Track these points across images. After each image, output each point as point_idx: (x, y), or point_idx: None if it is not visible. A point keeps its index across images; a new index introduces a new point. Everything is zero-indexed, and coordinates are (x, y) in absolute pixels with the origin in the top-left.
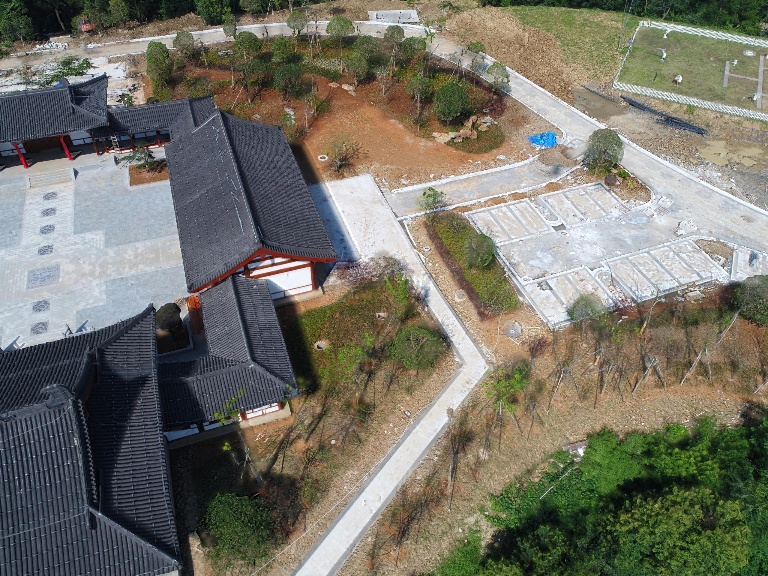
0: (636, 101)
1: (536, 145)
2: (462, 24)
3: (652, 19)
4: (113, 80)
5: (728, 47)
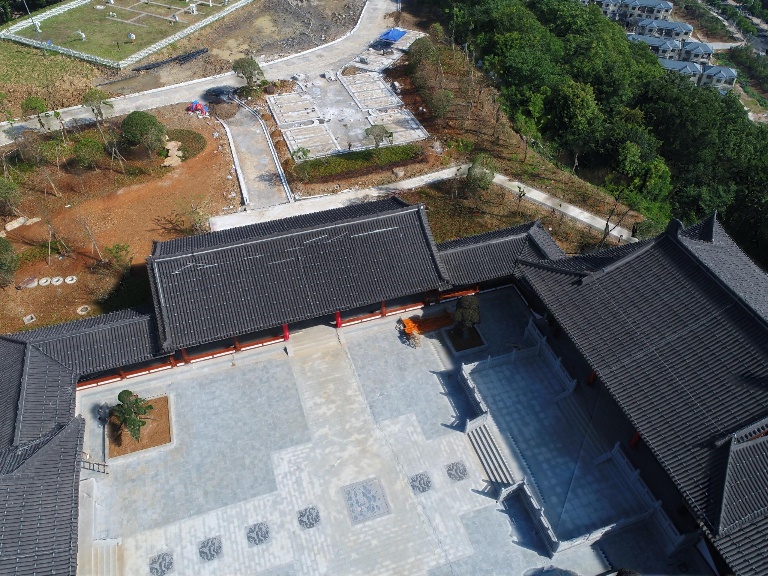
0: (144, 65)
1: (203, 116)
2: None
3: None
4: None
5: (82, 12)
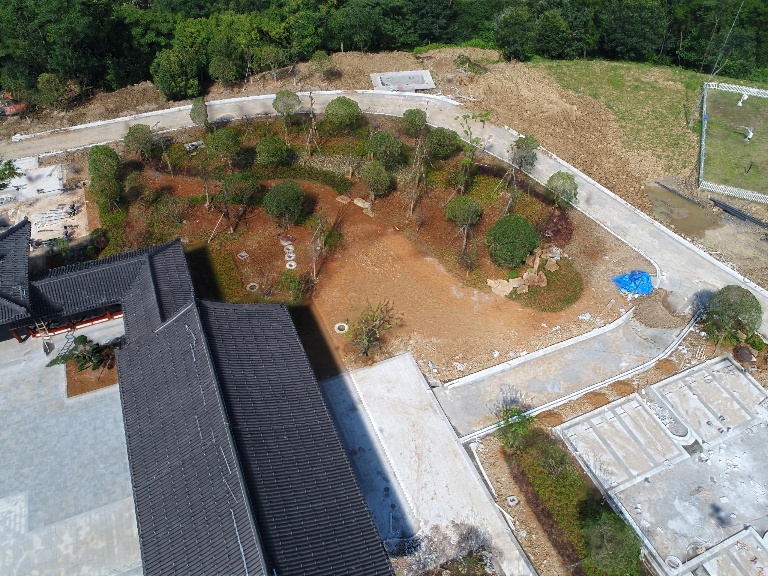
0: (731, 206)
1: (626, 292)
2: (490, 92)
3: (715, 76)
4: (45, 195)
5: None
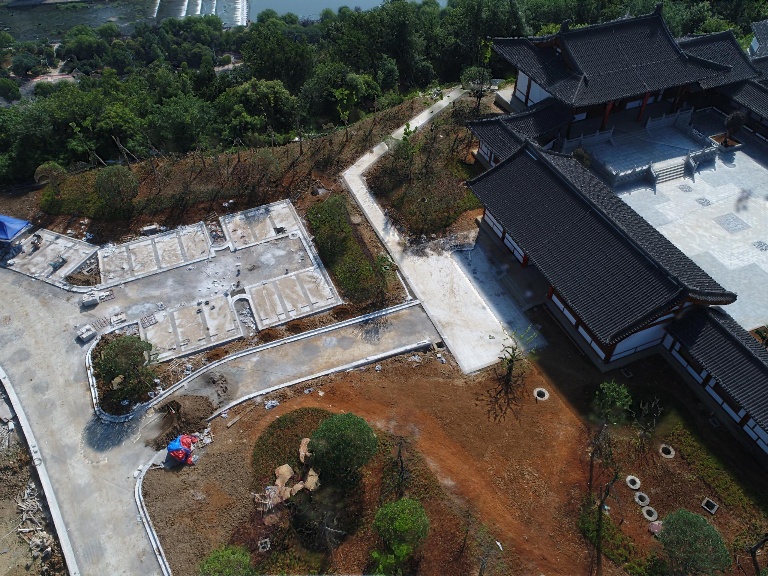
0: None
1: (206, 438)
2: None
3: None
4: None
5: None
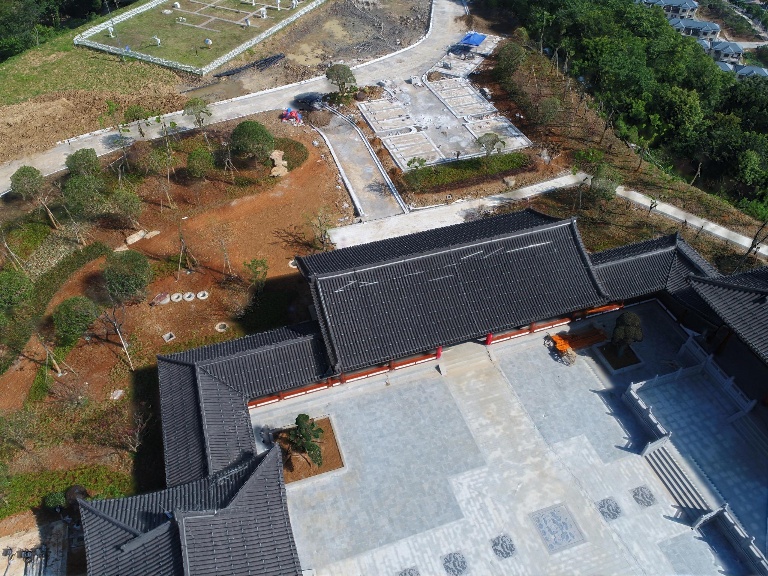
0: None
1: (298, 124)
2: None
3: (62, 36)
4: None
5: (150, 16)
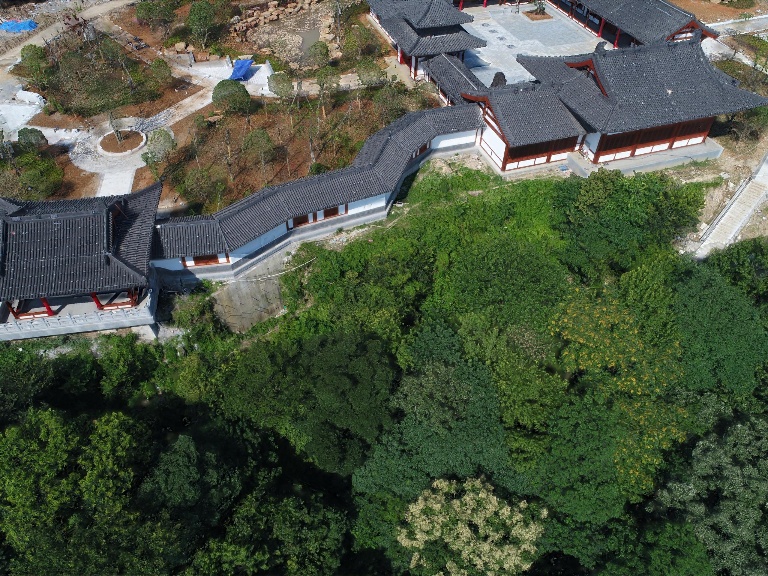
0: None
1: None
2: None
3: None
4: None
5: None
